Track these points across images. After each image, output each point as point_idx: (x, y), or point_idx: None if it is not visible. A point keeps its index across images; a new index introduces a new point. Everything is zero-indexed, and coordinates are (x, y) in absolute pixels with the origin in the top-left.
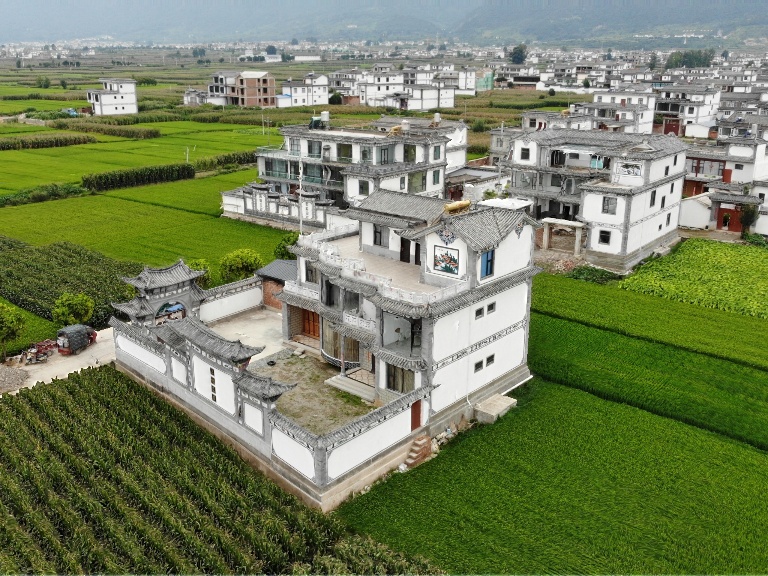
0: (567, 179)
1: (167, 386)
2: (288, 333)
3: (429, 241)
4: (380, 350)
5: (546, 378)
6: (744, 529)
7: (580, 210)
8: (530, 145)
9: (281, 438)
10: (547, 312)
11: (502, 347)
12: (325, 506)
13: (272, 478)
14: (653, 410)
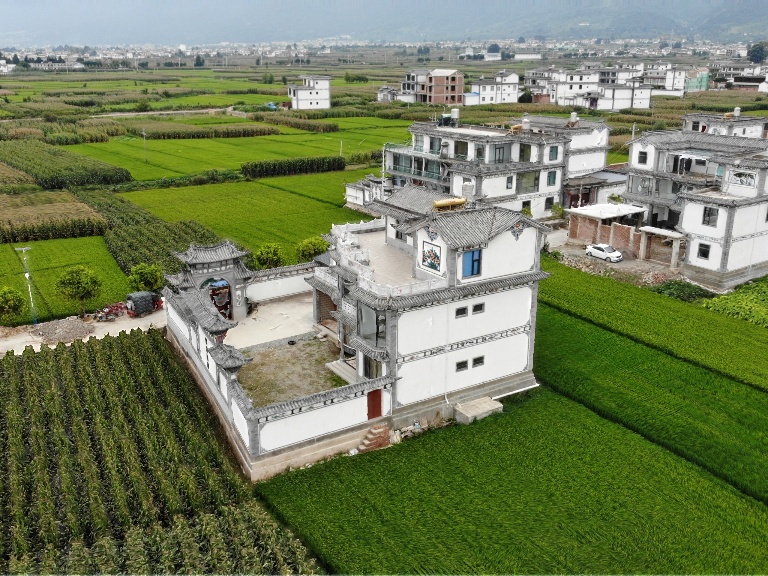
0: (684, 186)
1: (189, 352)
2: (317, 317)
3: (419, 236)
4: (355, 338)
5: (554, 389)
6: (656, 569)
7: (680, 220)
8: (648, 148)
9: (235, 407)
10: (601, 323)
11: (496, 350)
12: (256, 474)
13: (231, 443)
14: (646, 435)
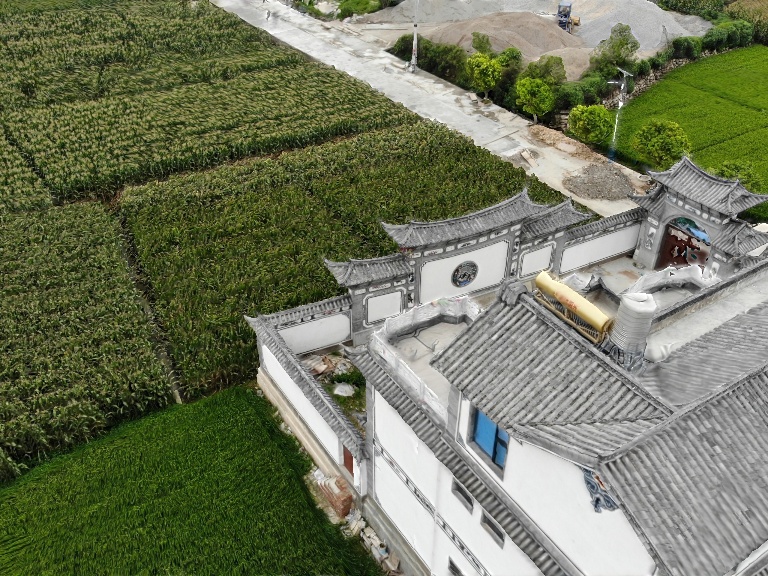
0: None
1: None
2: None
3: None
4: None
5: None
6: None
7: None
8: None
9: None
10: None
11: None
12: None
13: None
14: None
